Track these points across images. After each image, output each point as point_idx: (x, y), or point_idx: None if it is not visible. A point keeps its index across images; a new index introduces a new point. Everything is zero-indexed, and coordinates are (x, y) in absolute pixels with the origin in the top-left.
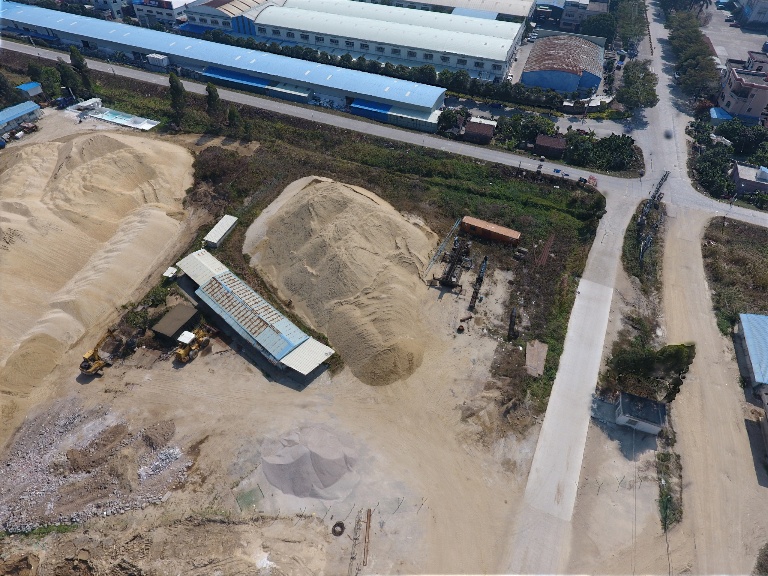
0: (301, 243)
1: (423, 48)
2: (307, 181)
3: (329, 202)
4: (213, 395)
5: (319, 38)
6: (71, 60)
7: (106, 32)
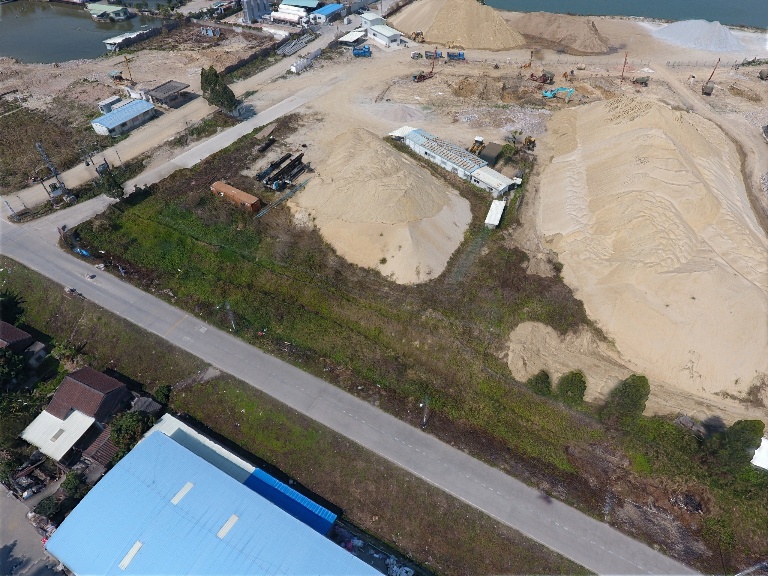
0: None
1: None
2: (416, 233)
3: None
4: (455, 134)
5: None
6: None
7: None
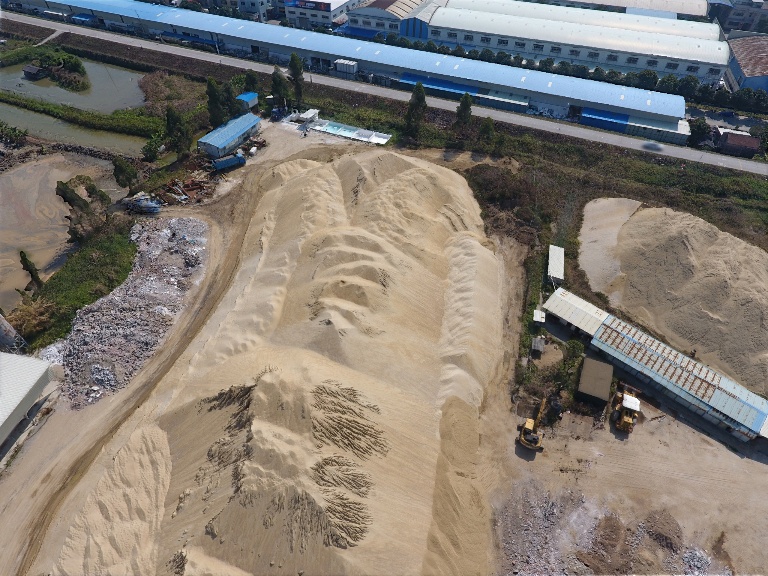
0: (679, 282)
1: (628, 51)
2: (627, 205)
3: (699, 233)
4: (690, 476)
5: (503, 41)
6: (290, 68)
7: (280, 36)
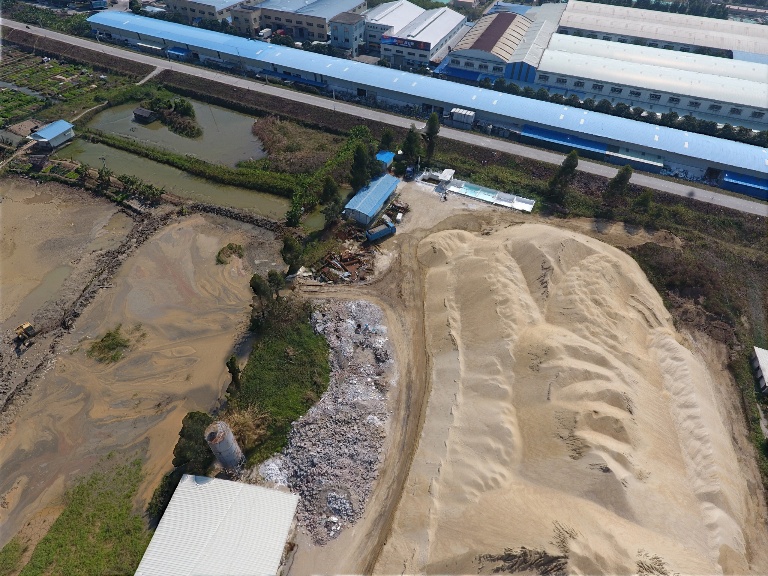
0: None
1: (755, 106)
2: None
3: None
4: None
5: (616, 89)
6: (427, 127)
7: (390, 81)
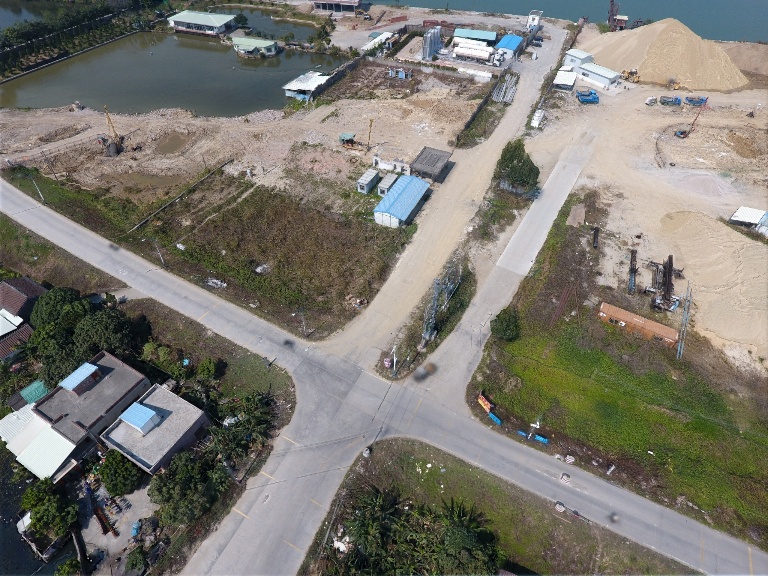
0: None
1: None
2: None
3: None
4: None
5: None
6: None
7: None
